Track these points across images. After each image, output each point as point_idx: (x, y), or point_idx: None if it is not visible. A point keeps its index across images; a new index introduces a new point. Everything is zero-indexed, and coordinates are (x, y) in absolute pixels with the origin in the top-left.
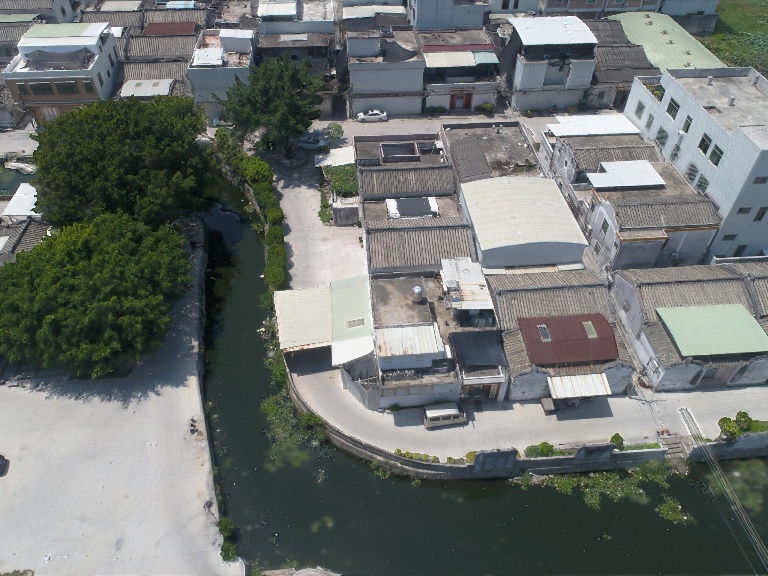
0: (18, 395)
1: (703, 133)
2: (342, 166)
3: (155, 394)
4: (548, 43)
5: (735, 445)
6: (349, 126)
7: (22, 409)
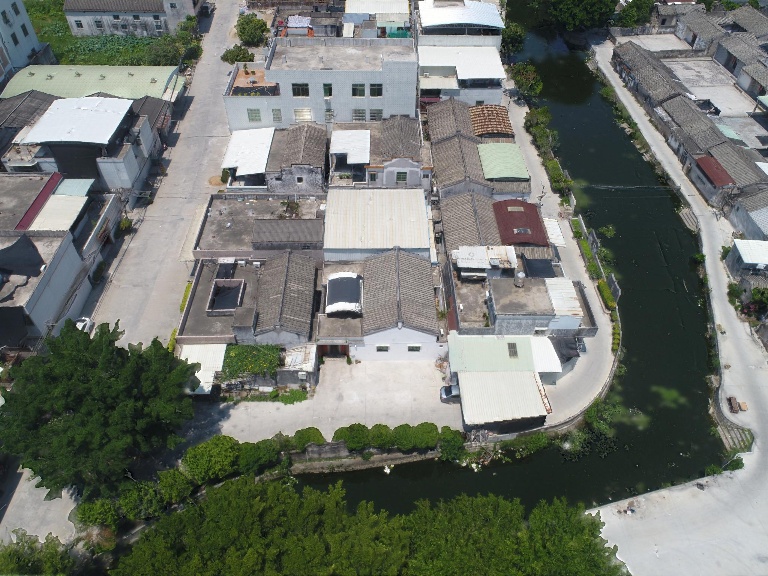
0: None
1: (351, 85)
2: (226, 359)
3: None
4: (114, 128)
5: None
6: None
7: None
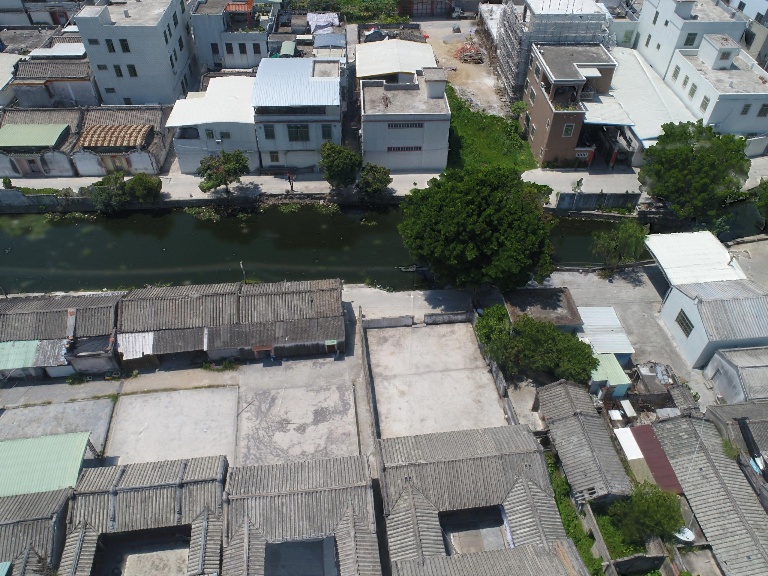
0: None
1: None
2: None
3: None
4: None
5: (2, 200)
6: None
7: None
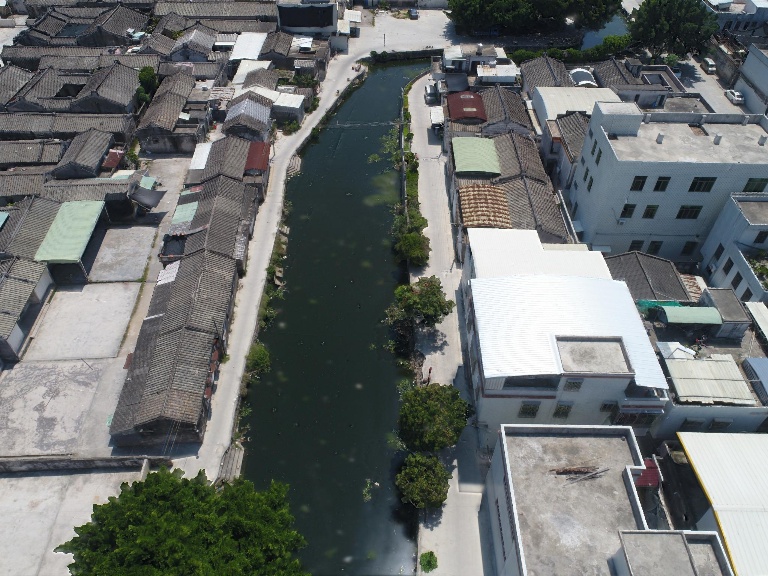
0: (447, 18)
1: None
2: None
3: (447, 40)
4: None
5: None
6: (715, 90)
7: (440, 19)
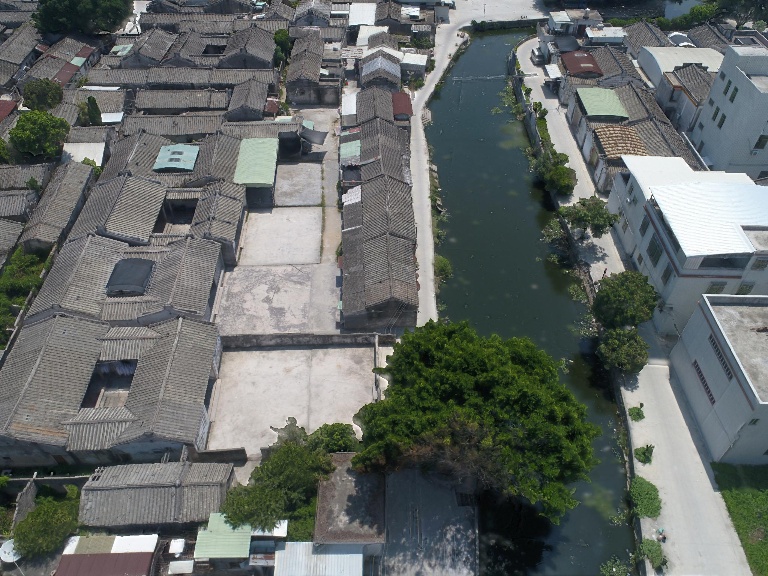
0: None
1: None
2: None
3: None
4: None
5: None
6: None
7: None
